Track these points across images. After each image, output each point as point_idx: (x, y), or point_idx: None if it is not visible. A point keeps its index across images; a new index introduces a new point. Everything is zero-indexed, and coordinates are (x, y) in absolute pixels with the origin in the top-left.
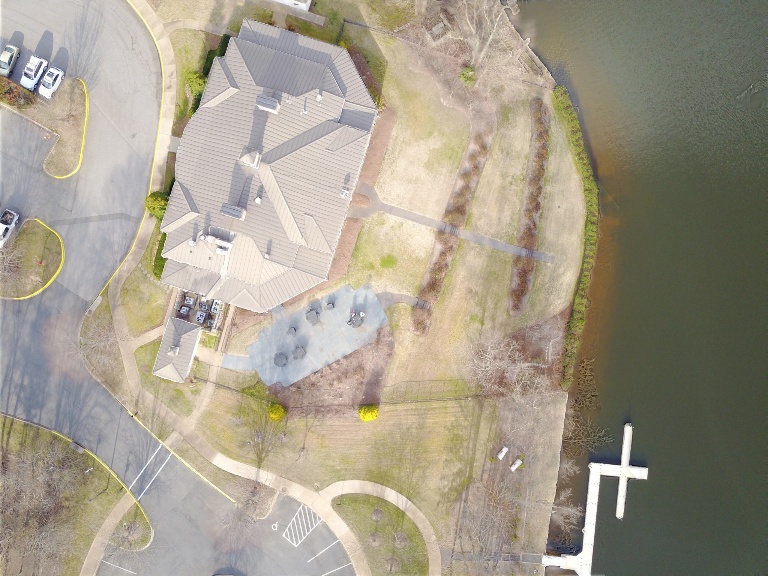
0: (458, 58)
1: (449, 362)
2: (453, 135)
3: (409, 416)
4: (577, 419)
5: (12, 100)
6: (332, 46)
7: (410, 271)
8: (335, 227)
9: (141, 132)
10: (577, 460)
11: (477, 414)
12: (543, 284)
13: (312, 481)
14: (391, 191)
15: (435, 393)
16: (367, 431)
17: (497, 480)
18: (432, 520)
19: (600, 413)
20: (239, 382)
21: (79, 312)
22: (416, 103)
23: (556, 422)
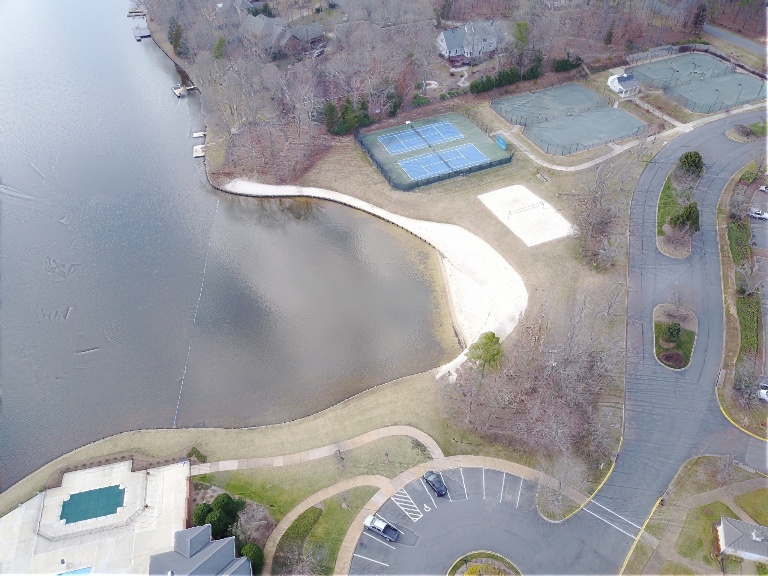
0: None
1: None
2: None
3: None
4: None
5: None
6: None
7: None
8: None
9: None
10: None
11: None
12: None
13: None
14: None
15: None
16: None
17: None
18: None
19: None
20: None
21: None
22: None
23: None
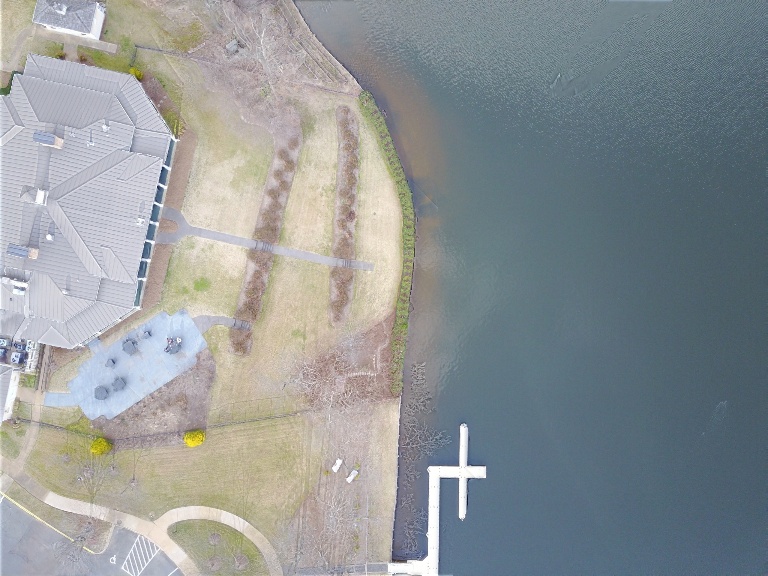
0: (258, 73)
1: (274, 379)
2: (256, 152)
3: (238, 437)
4: (413, 424)
5: None
6: (119, 74)
7: (225, 292)
8: (134, 256)
9: None
10: (416, 465)
11: (308, 429)
12: (364, 292)
13: (146, 511)
14: (198, 214)
15: (263, 412)
16: (196, 456)
17: (334, 493)
18: (271, 539)
19: (436, 416)
20: (63, 419)
21: None
22: (216, 123)
23: (391, 429)
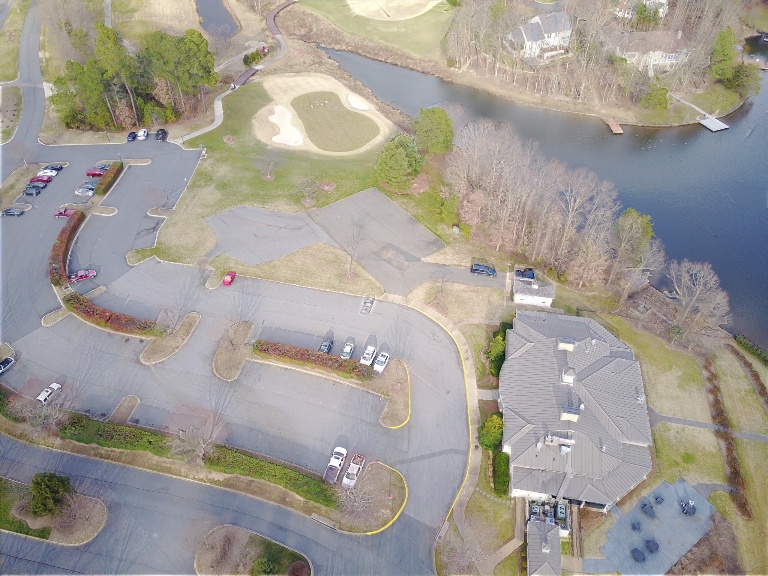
0: (661, 325)
1: None
2: (687, 367)
3: None
4: None
5: (358, 373)
6: (583, 318)
7: (710, 464)
8: (644, 425)
9: (453, 389)
10: None
11: None
12: None
13: None
14: (663, 407)
15: None
16: None
17: None
18: None
19: None
20: None
21: (429, 539)
22: (650, 350)
23: None
